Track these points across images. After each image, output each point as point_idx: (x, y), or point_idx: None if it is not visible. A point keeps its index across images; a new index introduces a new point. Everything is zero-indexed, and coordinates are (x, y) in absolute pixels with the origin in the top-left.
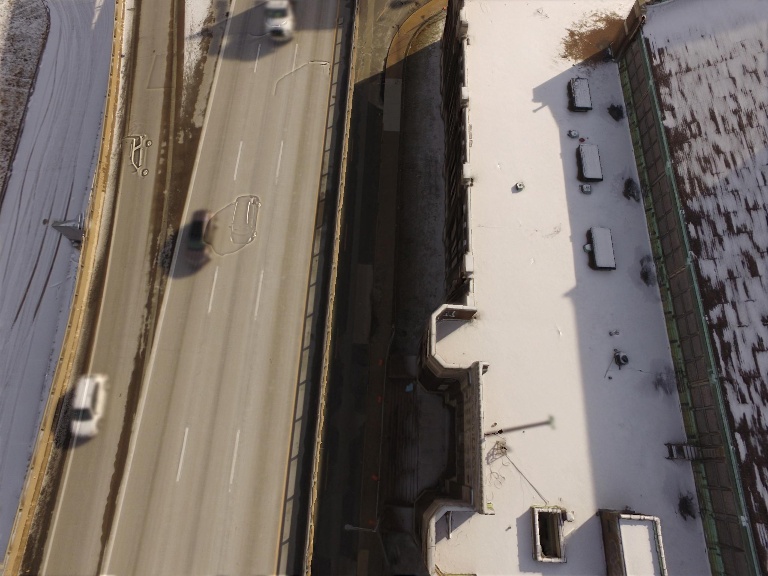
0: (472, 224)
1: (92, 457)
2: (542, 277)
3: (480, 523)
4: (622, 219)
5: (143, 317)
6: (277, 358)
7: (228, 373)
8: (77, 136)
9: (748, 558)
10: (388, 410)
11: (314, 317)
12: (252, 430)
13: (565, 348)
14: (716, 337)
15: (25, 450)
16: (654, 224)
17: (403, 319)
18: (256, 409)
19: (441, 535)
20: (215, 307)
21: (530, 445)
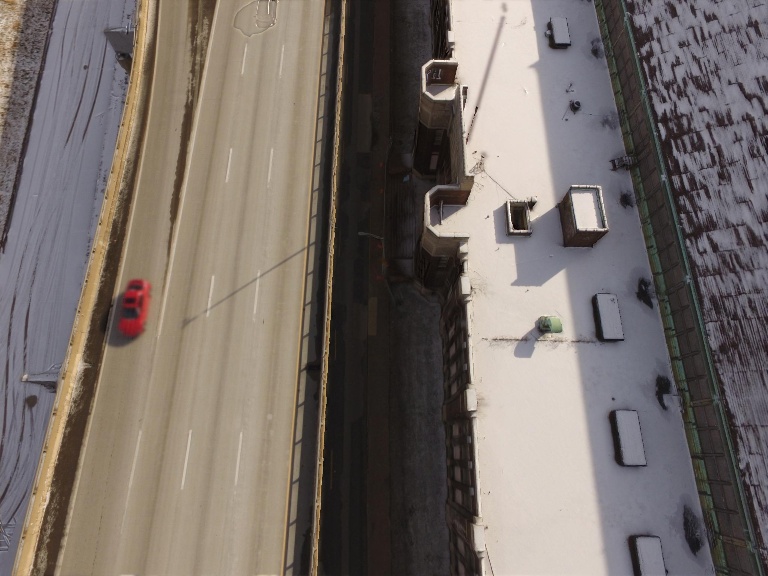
0: (453, 20)
1: (157, 169)
2: (511, 55)
3: (465, 215)
4: (576, 14)
5: (189, 79)
6: (299, 102)
7: (261, 113)
8: (107, 1)
9: (667, 204)
10: (389, 198)
11: (327, 75)
12: (283, 148)
13: (530, 101)
14: (645, 65)
15: (85, 235)
16: (602, 14)
17: (399, 133)
18: (285, 135)
19: (435, 223)
20: (247, 70)
21: (503, 165)
